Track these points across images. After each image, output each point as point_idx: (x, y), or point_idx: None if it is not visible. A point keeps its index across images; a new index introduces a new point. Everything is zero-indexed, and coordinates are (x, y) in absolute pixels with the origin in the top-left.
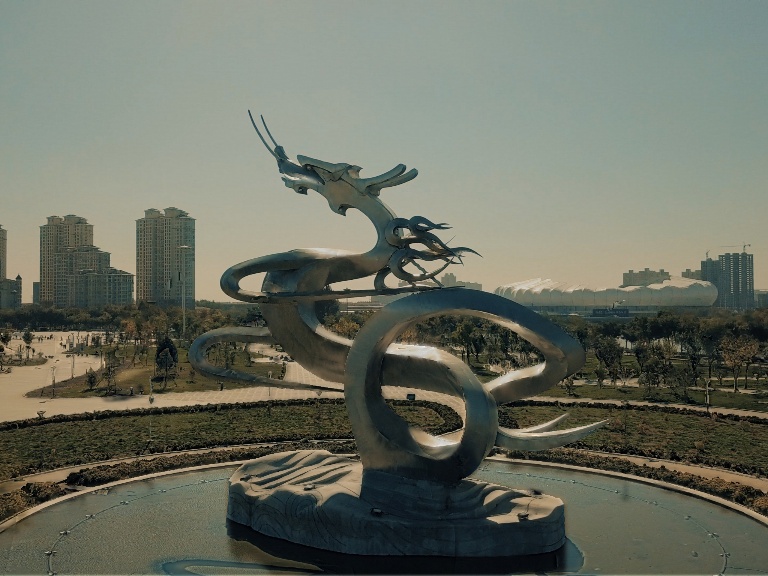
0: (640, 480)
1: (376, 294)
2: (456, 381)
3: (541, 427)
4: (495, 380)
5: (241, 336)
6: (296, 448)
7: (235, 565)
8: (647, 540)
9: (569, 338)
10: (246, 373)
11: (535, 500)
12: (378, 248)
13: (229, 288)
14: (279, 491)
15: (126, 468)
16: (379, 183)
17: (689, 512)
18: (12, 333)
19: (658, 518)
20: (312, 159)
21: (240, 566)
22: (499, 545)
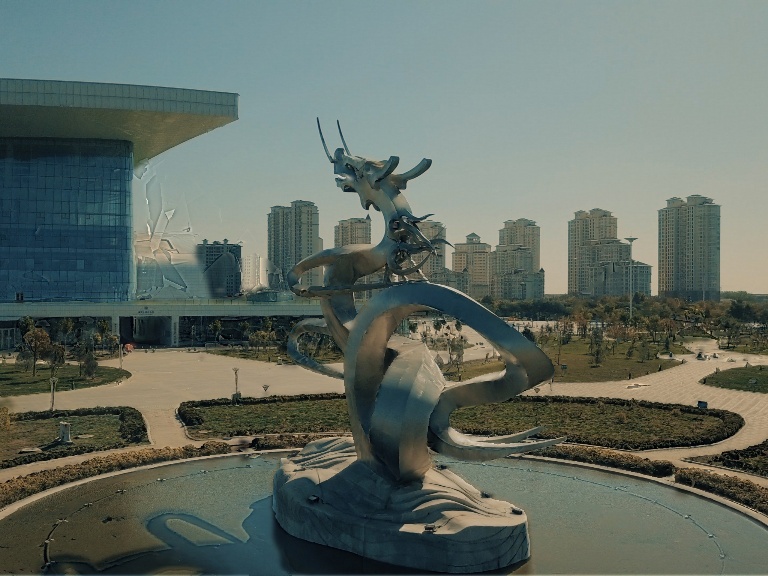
0: None
1: (370, 288)
2: None
3: (502, 438)
4: None
5: (313, 327)
6: None
7: (203, 524)
8: None
9: (522, 339)
10: None
11: (467, 516)
12: (383, 242)
13: None
14: (279, 469)
15: (297, 439)
16: (384, 177)
17: (743, 574)
18: (449, 321)
19: (684, 572)
20: (349, 158)
21: (203, 526)
22: (400, 553)
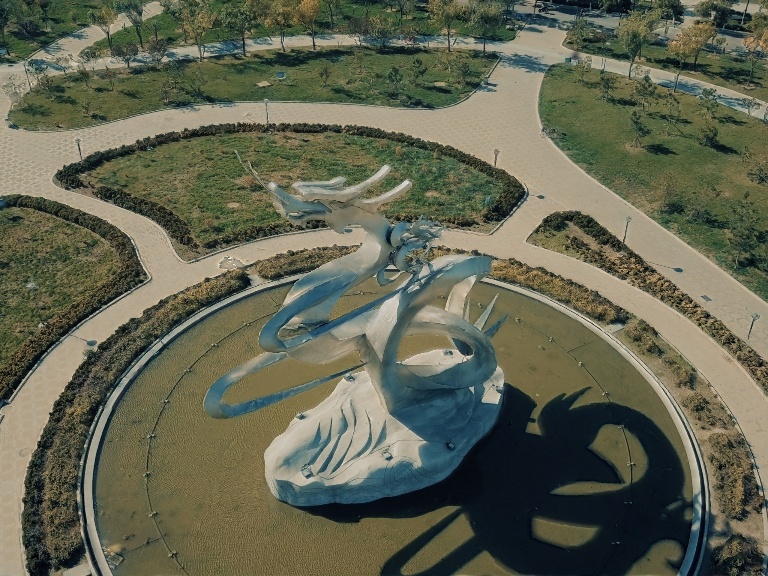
0: (392, 269)
1: None
2: (466, 334)
3: None
4: (452, 307)
5: None
6: (106, 370)
7: (416, 546)
8: (504, 346)
9: None
10: (270, 396)
11: None
12: (384, 253)
13: (278, 348)
14: (373, 473)
15: (62, 517)
16: None
17: None
18: None
19: None
20: (323, 194)
21: (422, 544)
22: None
